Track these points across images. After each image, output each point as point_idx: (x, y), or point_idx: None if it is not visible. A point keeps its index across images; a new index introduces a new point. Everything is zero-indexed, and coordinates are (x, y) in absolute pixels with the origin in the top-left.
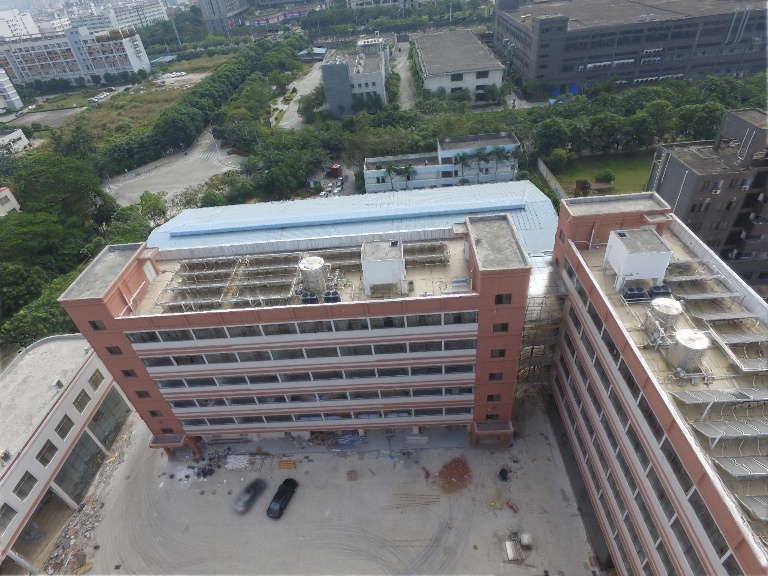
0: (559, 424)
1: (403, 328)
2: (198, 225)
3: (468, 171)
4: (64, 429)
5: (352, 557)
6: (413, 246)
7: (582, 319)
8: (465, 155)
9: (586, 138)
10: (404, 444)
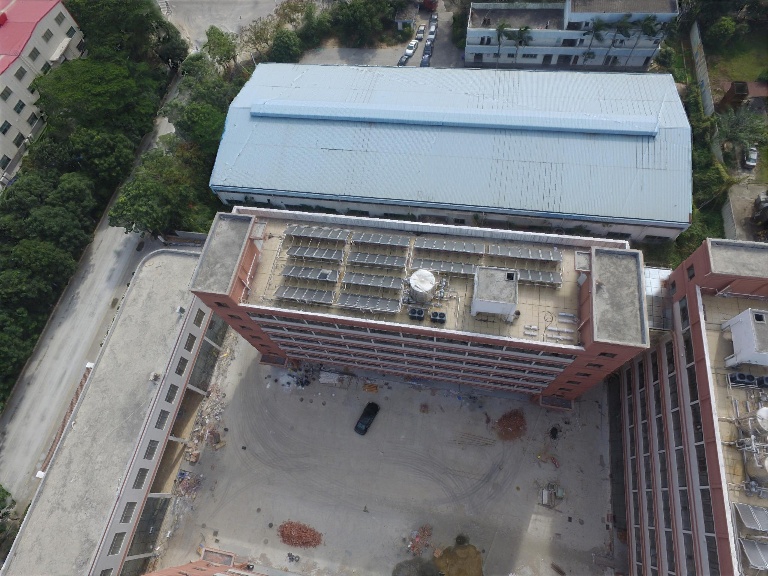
0: (616, 404)
1: (501, 350)
2: (279, 106)
3: (598, 42)
4: (190, 344)
5: (420, 476)
6: (526, 258)
7: (678, 367)
8: (601, 23)
9: None
10: (472, 389)
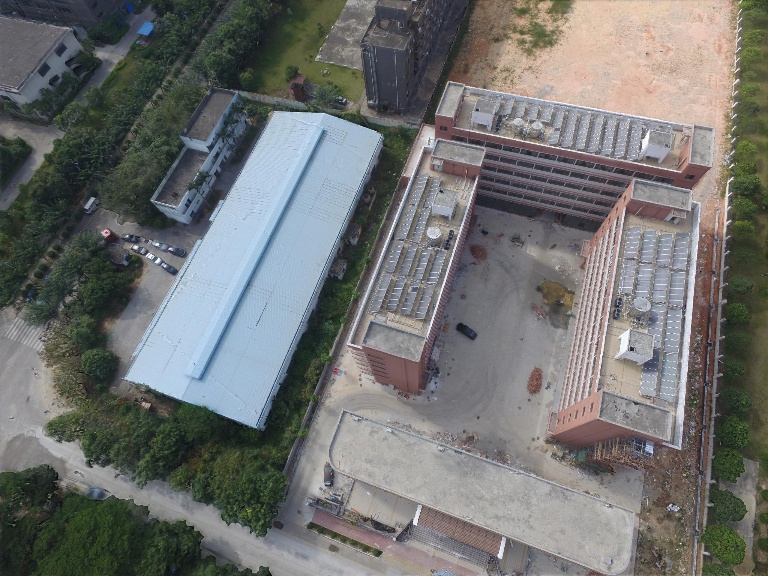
0: None
1: None
2: (203, 352)
3: None
4: None
5: (504, 305)
6: None
7: None
8: (222, 130)
9: (241, 52)
10: None
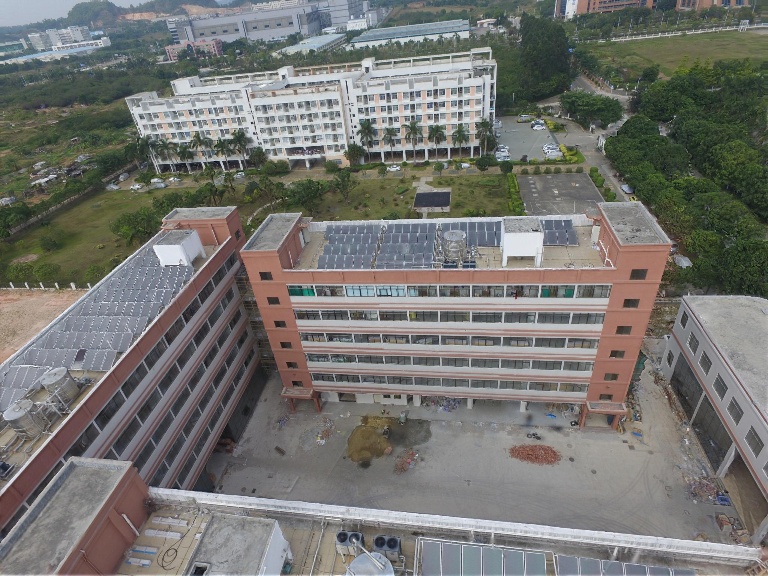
0: None
1: None
2: None
3: None
4: None
5: None
6: None
7: None
8: None
9: None
10: None
